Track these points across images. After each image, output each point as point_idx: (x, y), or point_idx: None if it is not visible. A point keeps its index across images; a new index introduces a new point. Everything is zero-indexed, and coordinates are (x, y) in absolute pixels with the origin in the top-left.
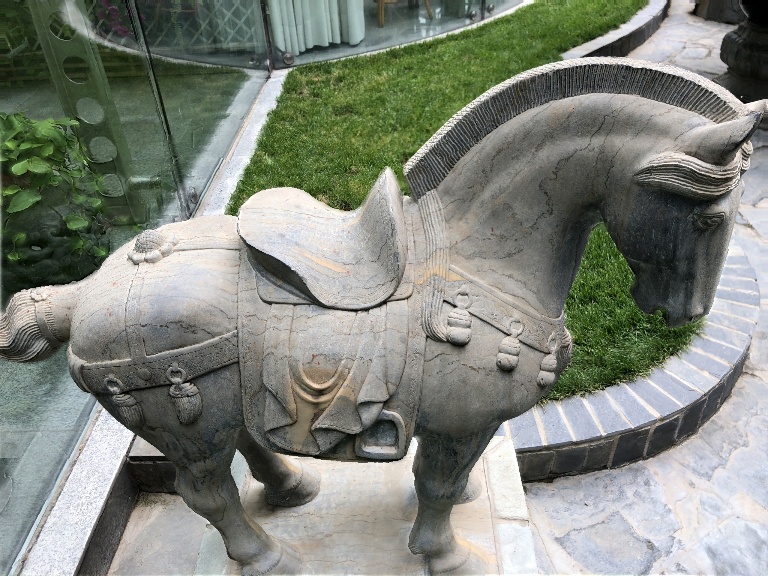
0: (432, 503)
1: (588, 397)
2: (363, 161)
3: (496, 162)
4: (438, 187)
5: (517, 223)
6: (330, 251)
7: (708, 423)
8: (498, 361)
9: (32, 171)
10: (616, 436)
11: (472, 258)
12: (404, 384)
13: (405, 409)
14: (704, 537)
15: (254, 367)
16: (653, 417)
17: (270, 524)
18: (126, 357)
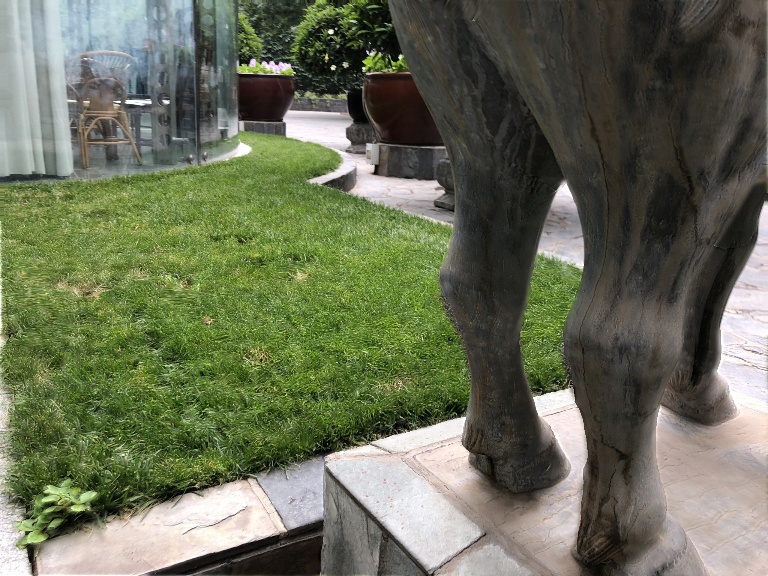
0: None
1: None
2: (169, 242)
3: None
4: None
5: None
6: None
7: None
8: None
9: None
10: None
11: None
12: None
13: None
14: None
15: None
16: None
17: (554, 516)
18: None
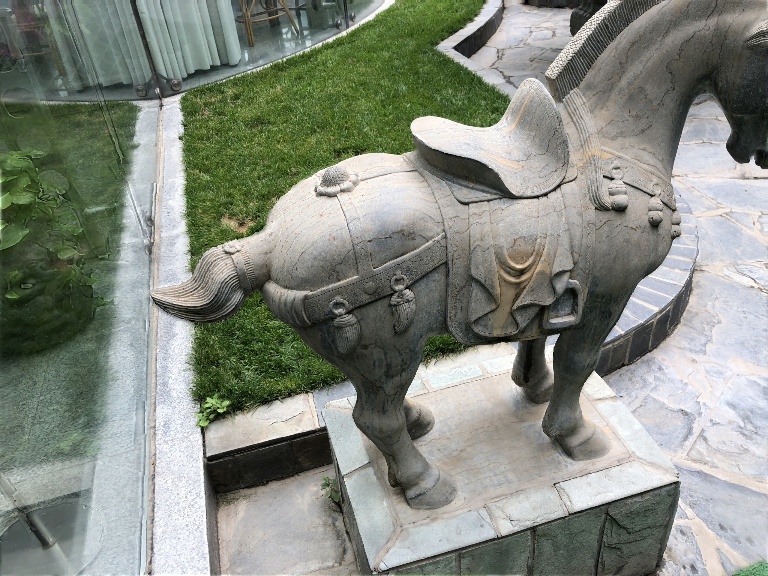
0: (577, 376)
1: None
2: (300, 162)
3: (630, 54)
4: (579, 85)
5: (648, 103)
6: (504, 153)
7: (685, 313)
8: (650, 218)
9: (16, 203)
10: (631, 333)
11: (616, 139)
12: (582, 253)
13: (582, 276)
14: (720, 396)
15: (461, 263)
16: (654, 311)
17: None
18: (353, 275)
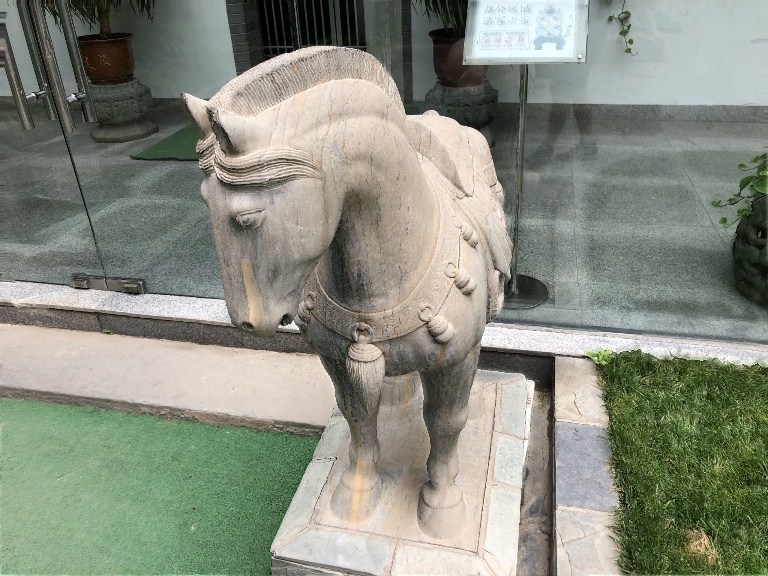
0: None
1: None
2: None
3: None
4: None
5: None
6: None
7: None
8: None
9: None
10: None
11: None
12: None
13: None
14: None
15: None
16: None
17: None
18: None
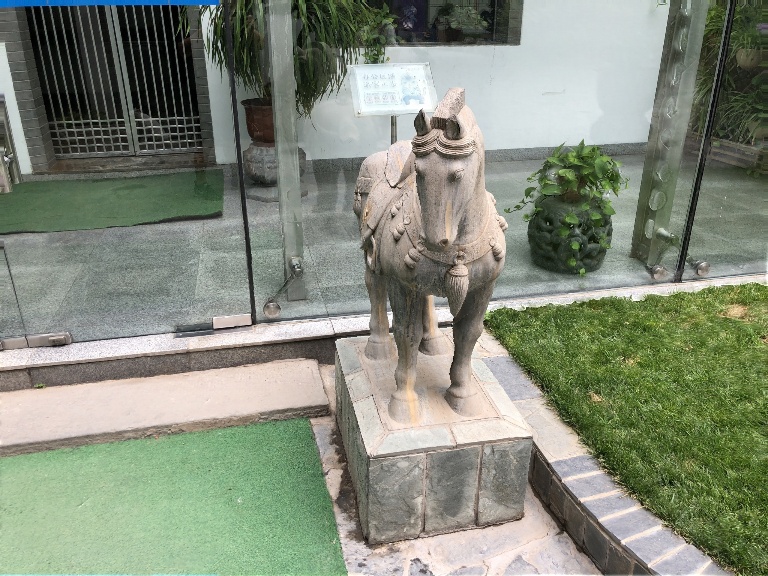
0: None
1: (665, 529)
2: None
3: None
4: None
5: None
6: None
7: None
8: None
9: (568, 177)
10: (633, 559)
11: None
12: (379, 226)
13: None
14: None
15: None
16: None
17: None
18: None
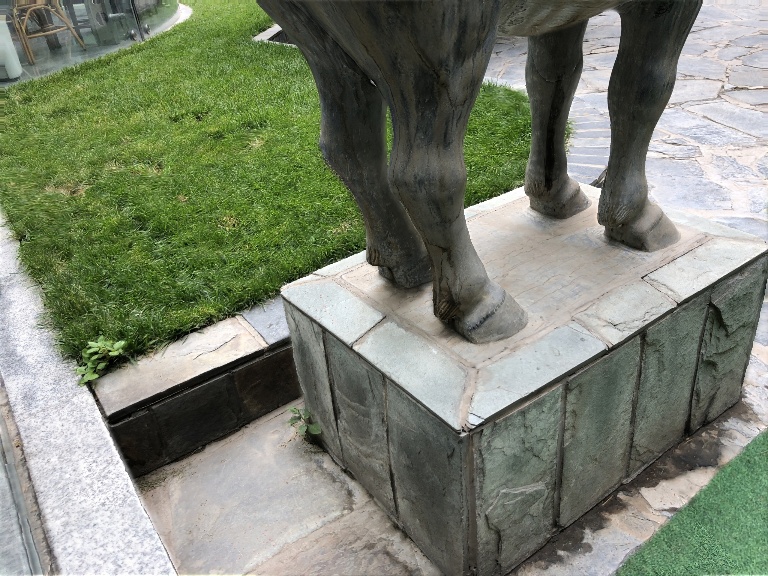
0: (654, 106)
1: None
2: (135, 130)
3: None
4: None
5: None
6: None
7: None
8: None
9: None
10: None
11: None
12: None
13: None
14: None
15: None
16: (603, 168)
17: None
18: None
